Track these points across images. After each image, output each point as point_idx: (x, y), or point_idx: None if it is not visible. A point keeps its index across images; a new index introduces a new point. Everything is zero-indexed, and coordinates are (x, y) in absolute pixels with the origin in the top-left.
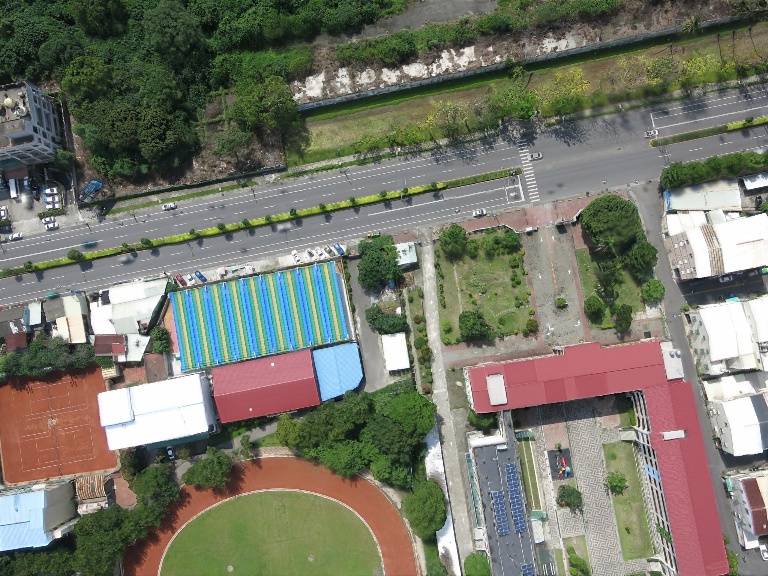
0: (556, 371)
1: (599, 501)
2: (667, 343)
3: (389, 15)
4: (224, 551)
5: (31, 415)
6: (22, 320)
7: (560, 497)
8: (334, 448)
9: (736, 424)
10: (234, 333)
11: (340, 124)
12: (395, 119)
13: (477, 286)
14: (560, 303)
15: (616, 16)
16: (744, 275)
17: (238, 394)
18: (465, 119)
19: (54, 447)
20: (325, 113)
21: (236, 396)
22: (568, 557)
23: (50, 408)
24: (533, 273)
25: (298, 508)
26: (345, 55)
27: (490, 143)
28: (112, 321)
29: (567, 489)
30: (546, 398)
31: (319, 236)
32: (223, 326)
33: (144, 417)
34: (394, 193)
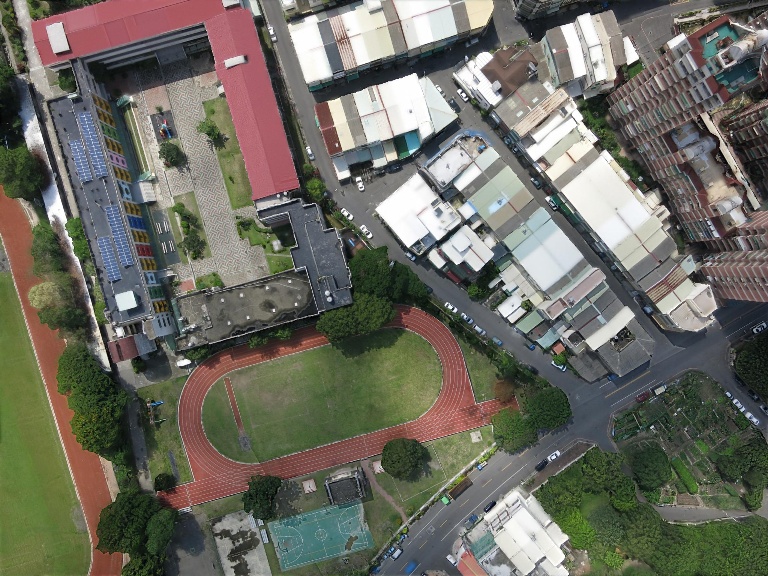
0: (115, 13)
1: (204, 157)
2: None
3: None
4: None
5: None
6: None
7: (161, 155)
8: None
9: (302, 49)
10: None
11: None
12: None
13: None
14: None
15: None
16: None
17: None
18: None
19: None
20: None
21: None
22: None
23: None
24: None
25: None
26: None
27: None
28: None
29: None
30: (110, 42)
31: None
32: None
33: None
34: None
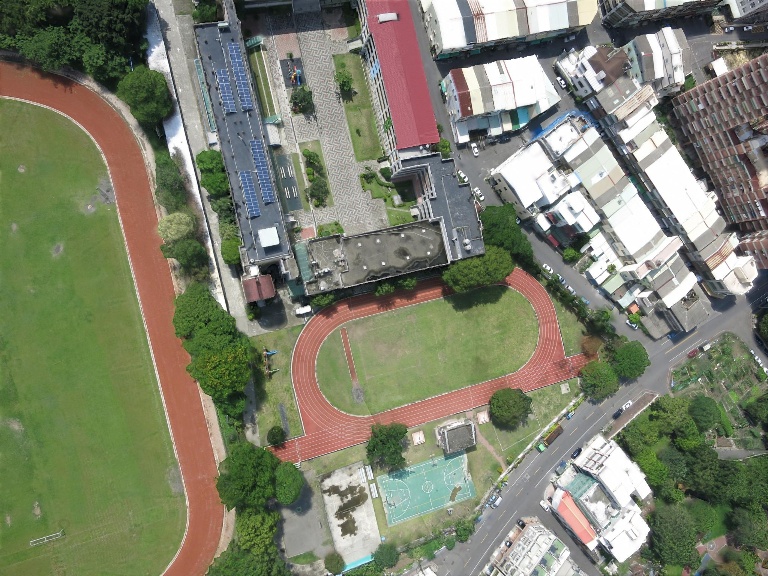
0: None
1: (332, 108)
2: None
3: None
4: None
5: None
6: None
7: (293, 99)
8: (36, 36)
9: (443, 18)
10: None
11: None
12: None
13: None
14: None
15: None
16: None
17: None
18: None
19: None
20: None
21: None
22: (305, 160)
23: None
24: None
25: (0, 115)
26: None
27: None
28: None
29: (299, 91)
30: None
31: None
32: None
33: None
34: None
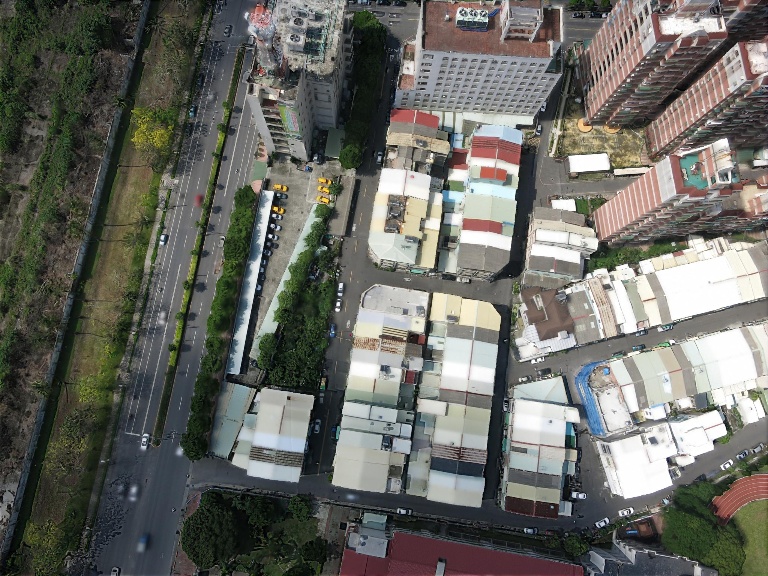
0: None
1: None
2: (351, 538)
3: None
4: None
5: None
6: None
7: None
8: None
9: (451, 497)
10: None
11: None
12: None
13: None
14: None
15: (7, 428)
16: (320, 408)
17: None
18: None
19: None
20: None
21: None
22: None
23: None
24: None
25: None
26: None
27: None
28: None
29: None
30: None
31: None
32: None
33: None
34: None
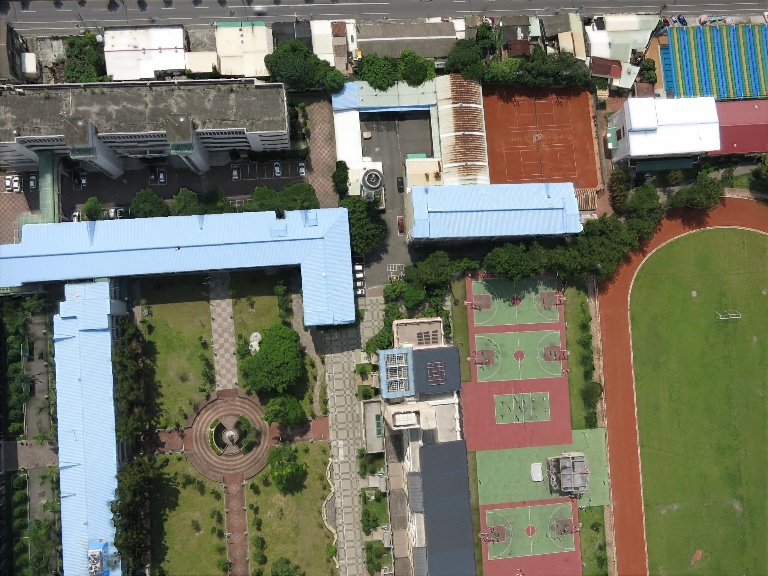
0: None
1: None
2: None
3: None
4: (689, 277)
5: (517, 127)
6: (530, 27)
7: None
8: None
9: None
10: (722, 73)
11: None
12: None
13: None
14: None
15: None
16: None
17: (729, 128)
18: None
19: (538, 161)
20: None
21: (726, 129)
22: None
23: (537, 123)
24: None
25: (756, 246)
26: None
27: None
28: (610, 45)
29: None
30: None
31: None
32: (713, 65)
33: (665, 128)
34: None
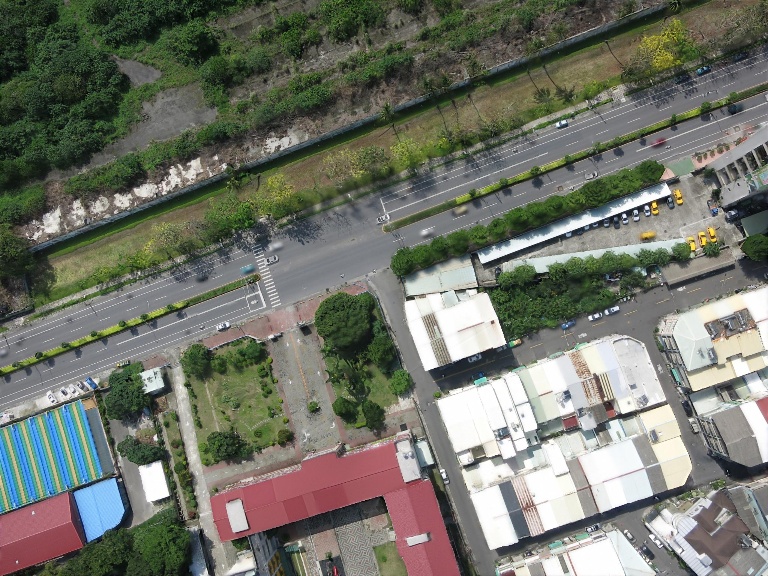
0: (294, 488)
1: None
2: (404, 442)
3: (114, 140)
4: None
5: None
6: None
7: None
8: None
9: (485, 517)
10: None
11: (82, 256)
12: (134, 242)
13: (229, 402)
14: (310, 408)
15: (335, 104)
16: (492, 352)
17: (1, 549)
18: (178, 242)
19: None
20: (65, 248)
21: None
22: None
23: None
24: (283, 380)
25: None
26: (73, 189)
27: (226, 253)
28: None
29: None
30: (288, 517)
31: (72, 373)
32: None
33: None
34: (137, 319)
